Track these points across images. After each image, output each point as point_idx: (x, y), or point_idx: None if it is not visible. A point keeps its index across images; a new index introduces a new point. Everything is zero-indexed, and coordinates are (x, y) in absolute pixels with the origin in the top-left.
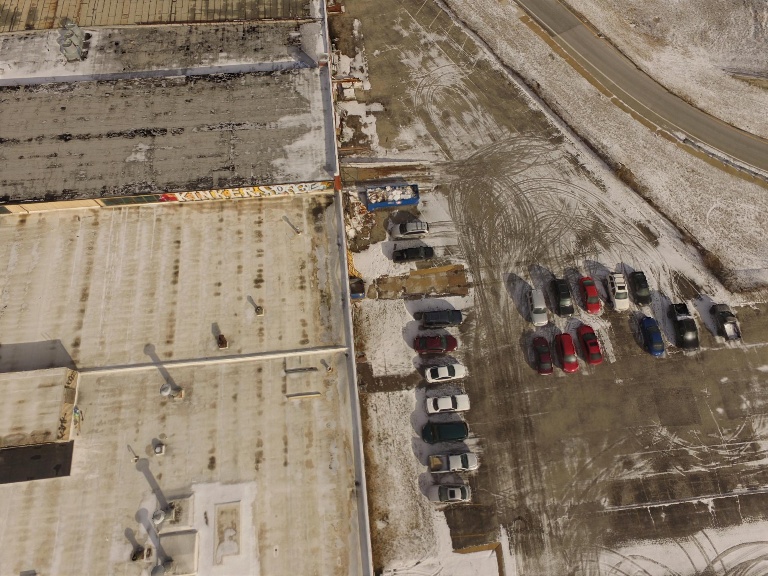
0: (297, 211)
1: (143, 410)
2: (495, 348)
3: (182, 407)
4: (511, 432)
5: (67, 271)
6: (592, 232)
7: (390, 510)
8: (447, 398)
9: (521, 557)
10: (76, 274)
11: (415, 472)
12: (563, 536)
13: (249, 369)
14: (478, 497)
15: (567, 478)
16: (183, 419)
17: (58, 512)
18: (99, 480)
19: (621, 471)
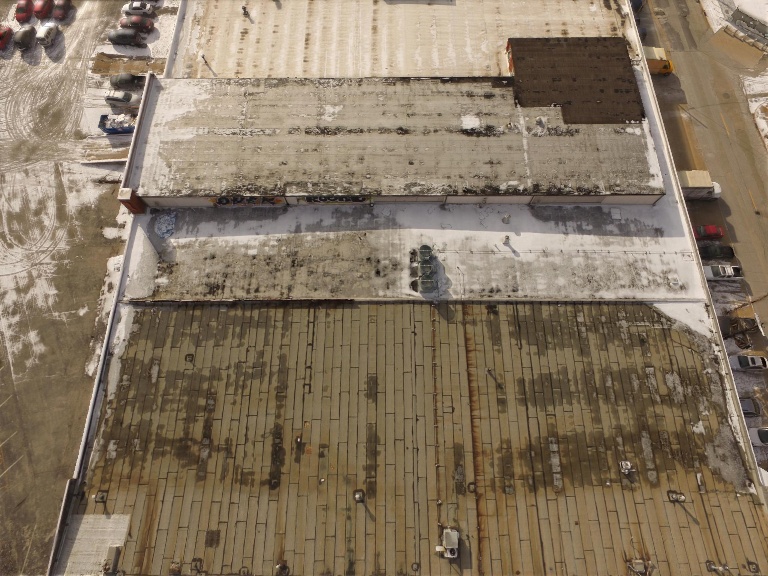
0: None
1: None
2: (95, 20)
3: None
4: None
5: (391, 45)
6: None
7: None
8: None
9: None
10: (383, 42)
11: None
12: None
13: None
14: None
15: None
16: None
17: None
18: None
19: None
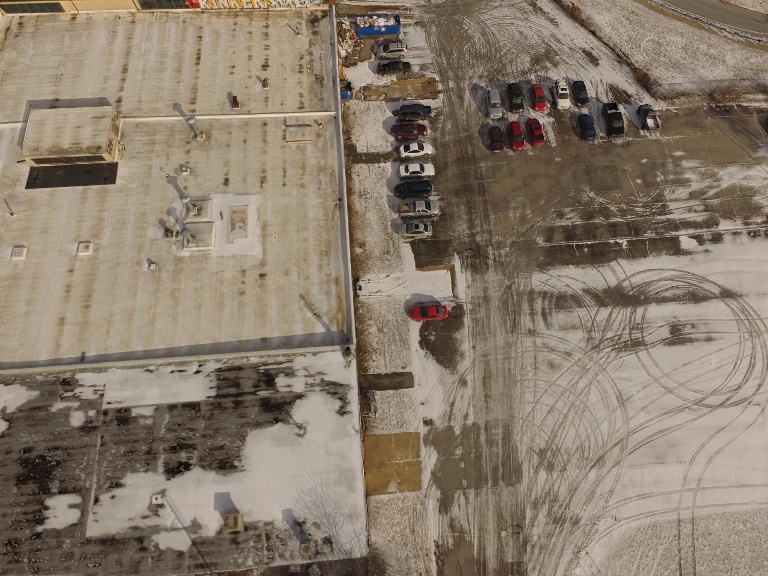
0: (298, 20)
1: (172, 146)
2: (458, 135)
3: (203, 145)
4: (467, 192)
5: (111, 53)
6: (544, 55)
7: (367, 241)
8: (416, 164)
9: (470, 274)
10: (118, 55)
11: (388, 218)
12: (504, 261)
13: (256, 123)
14: (438, 234)
15: (510, 223)
16: (204, 153)
17: (107, 206)
18: (138, 188)
19: (554, 220)
